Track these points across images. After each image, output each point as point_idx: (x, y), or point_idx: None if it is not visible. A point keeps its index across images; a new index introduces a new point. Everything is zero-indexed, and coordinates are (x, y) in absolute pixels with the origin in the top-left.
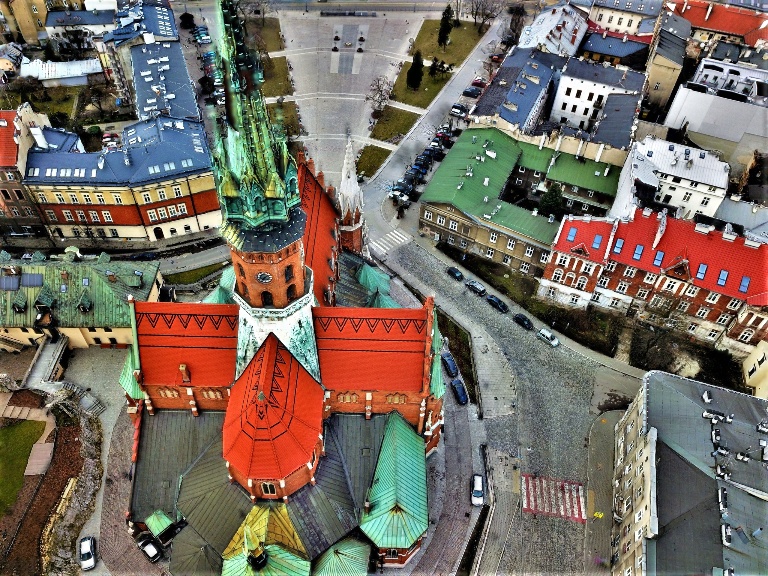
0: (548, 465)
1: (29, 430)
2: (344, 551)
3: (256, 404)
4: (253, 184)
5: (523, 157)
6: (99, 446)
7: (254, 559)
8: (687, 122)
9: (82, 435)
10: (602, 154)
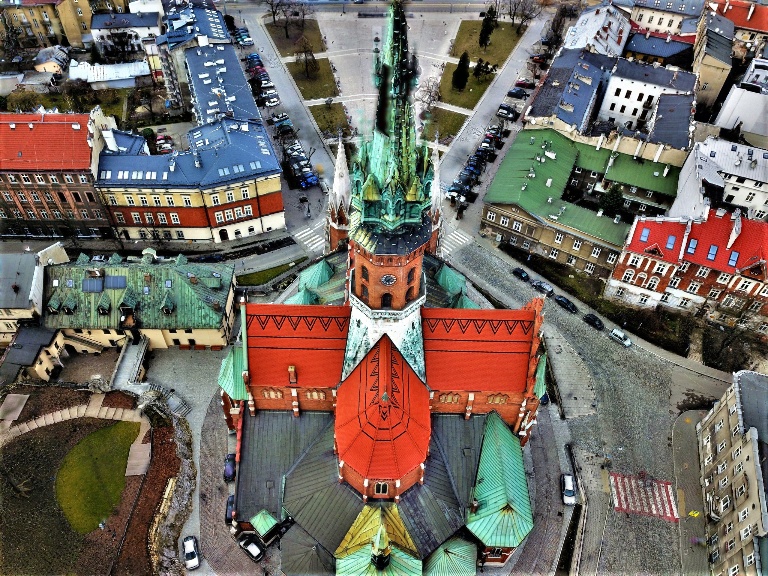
0: (635, 464)
1: (125, 431)
2: (453, 550)
3: (379, 405)
4: (397, 188)
5: (580, 158)
6: (190, 446)
7: (381, 558)
8: (741, 122)
9: (175, 436)
10: (661, 154)
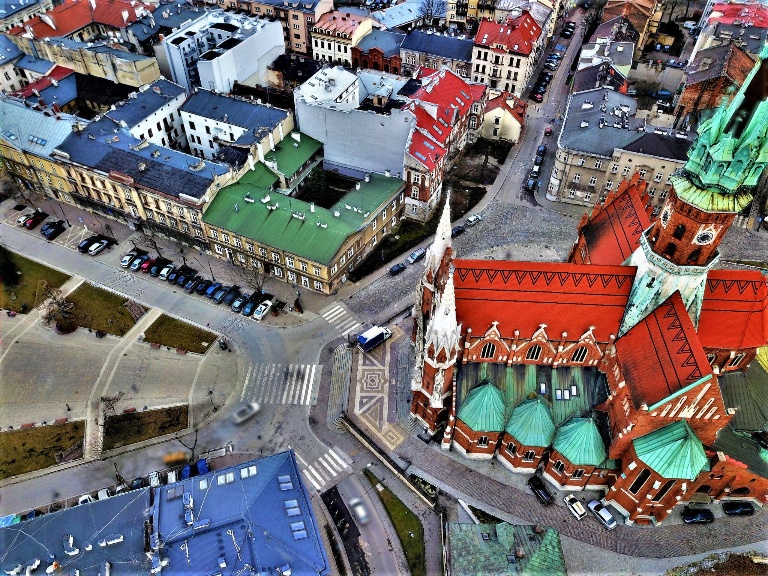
0: None
1: None
2: None
3: (764, 281)
4: None
5: None
6: None
7: None
8: (235, 81)
9: None
10: (282, 131)
